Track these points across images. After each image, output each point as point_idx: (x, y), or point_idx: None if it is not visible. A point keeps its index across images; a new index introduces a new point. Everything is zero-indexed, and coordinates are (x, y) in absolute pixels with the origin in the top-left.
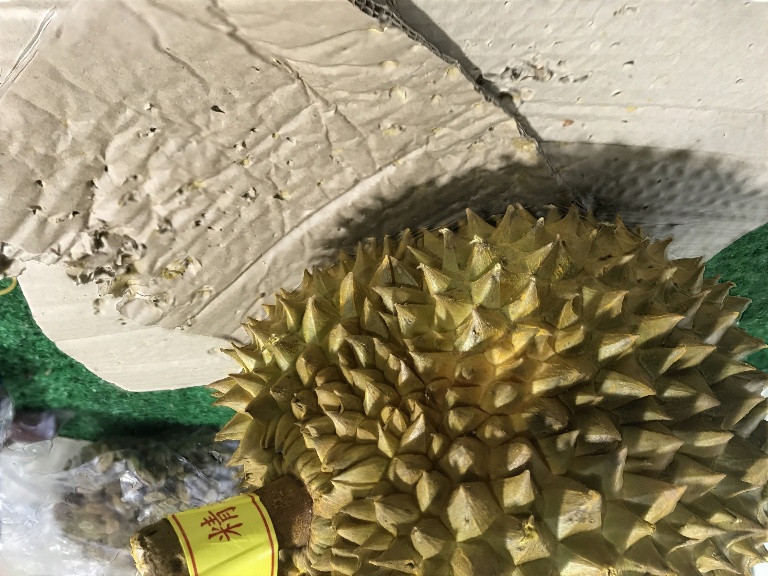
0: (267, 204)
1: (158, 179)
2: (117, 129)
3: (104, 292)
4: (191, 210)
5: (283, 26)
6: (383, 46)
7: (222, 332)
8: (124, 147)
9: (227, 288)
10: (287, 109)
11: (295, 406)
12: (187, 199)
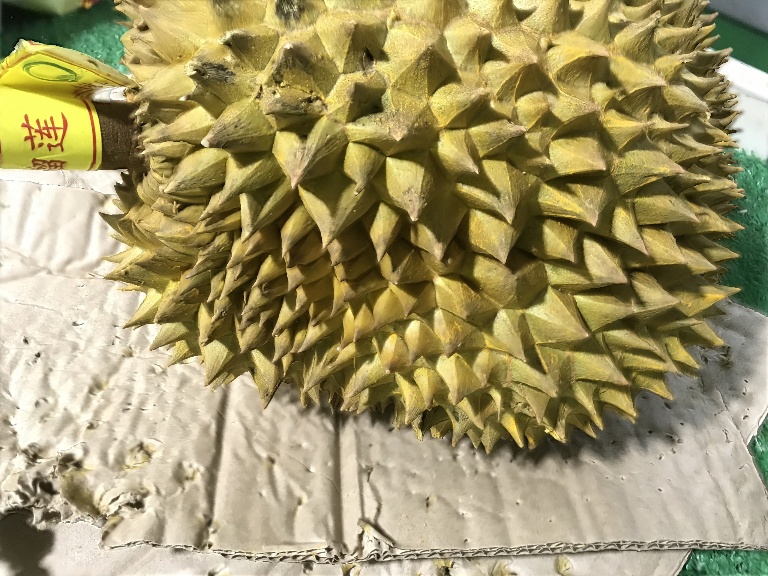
0: (181, 373)
1: (65, 391)
2: (9, 366)
3: (62, 506)
4: (114, 405)
5: (62, 236)
6: None
7: (276, 538)
8: (22, 379)
9: (220, 467)
10: (125, 299)
11: None
12: (103, 397)
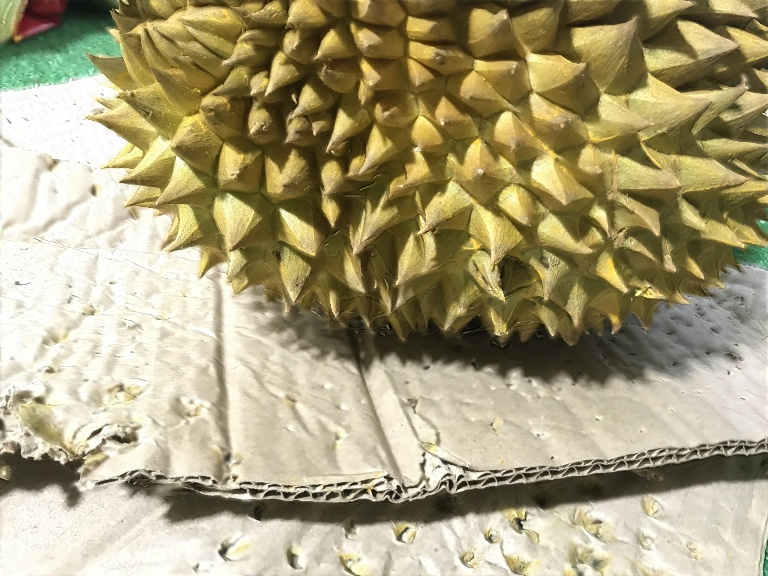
0: None
1: (11, 342)
2: None
3: (21, 438)
4: None
5: (0, 196)
6: (70, 174)
7: (318, 471)
8: None
9: (228, 406)
10: (80, 262)
11: (117, 31)
12: (62, 347)
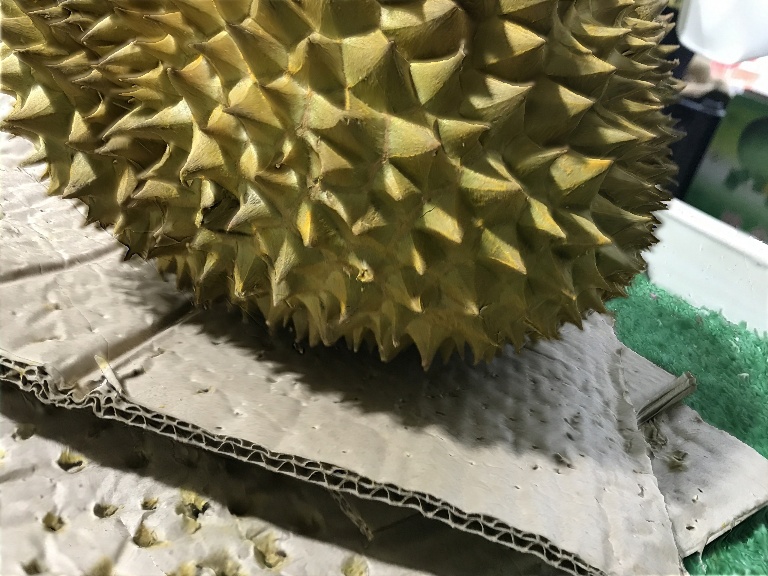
0: None
1: None
2: None
3: None
4: None
5: None
6: None
7: None
8: None
9: None
10: (34, 191)
11: None
12: None
